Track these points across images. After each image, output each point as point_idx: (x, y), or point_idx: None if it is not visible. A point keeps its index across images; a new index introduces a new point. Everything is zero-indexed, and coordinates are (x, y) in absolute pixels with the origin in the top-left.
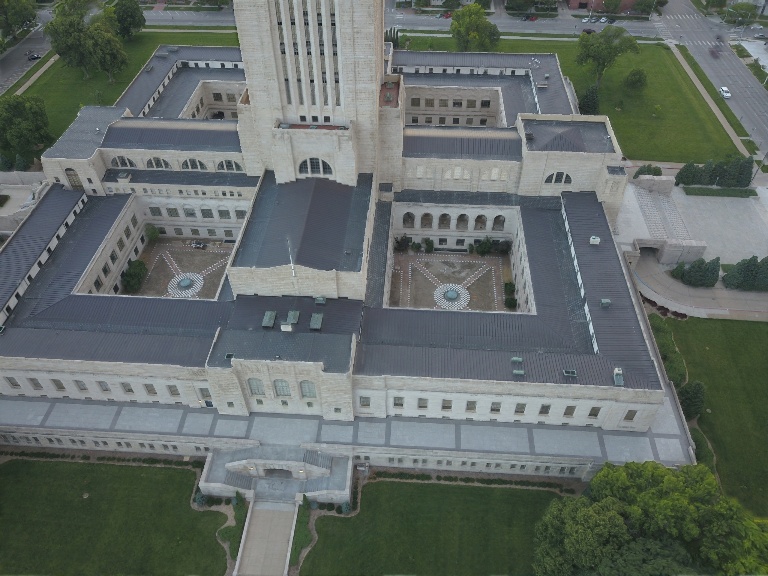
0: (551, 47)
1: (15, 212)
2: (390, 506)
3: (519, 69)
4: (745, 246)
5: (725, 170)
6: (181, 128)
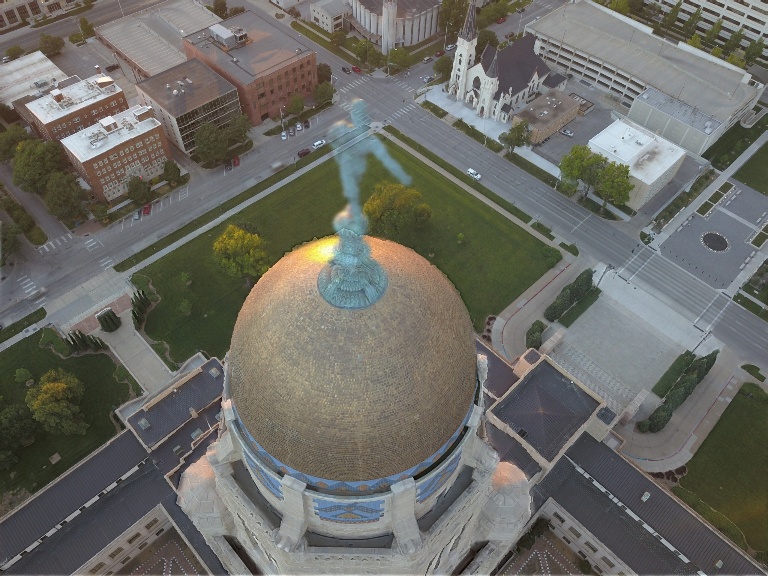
0: (296, 199)
1: None
2: None
3: None
4: (644, 356)
5: (577, 289)
6: None
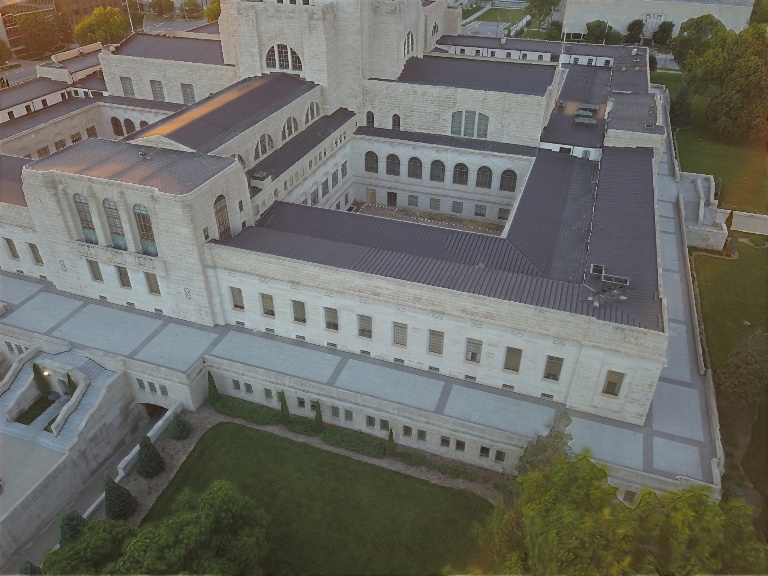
0: None
1: (80, 429)
2: None
3: None
4: None
5: None
6: (229, 100)
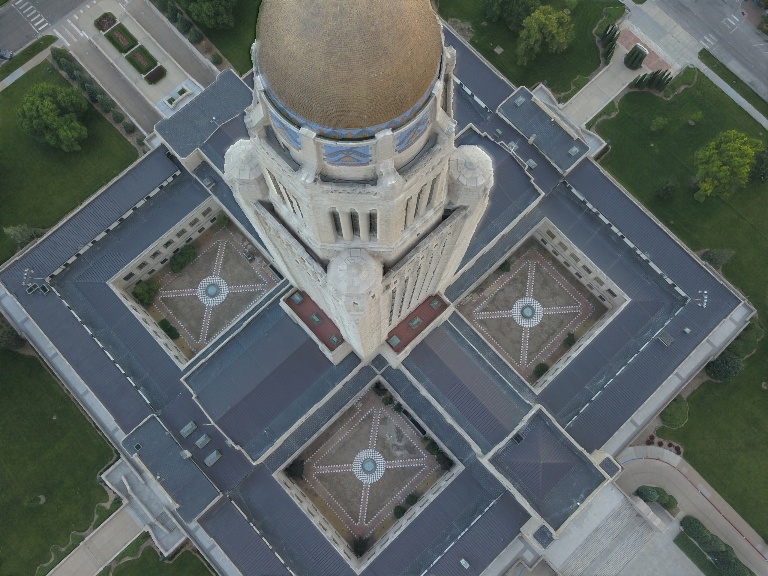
0: None
1: (154, 106)
2: (188, 575)
3: (681, 289)
4: None
5: (730, 562)
6: None
